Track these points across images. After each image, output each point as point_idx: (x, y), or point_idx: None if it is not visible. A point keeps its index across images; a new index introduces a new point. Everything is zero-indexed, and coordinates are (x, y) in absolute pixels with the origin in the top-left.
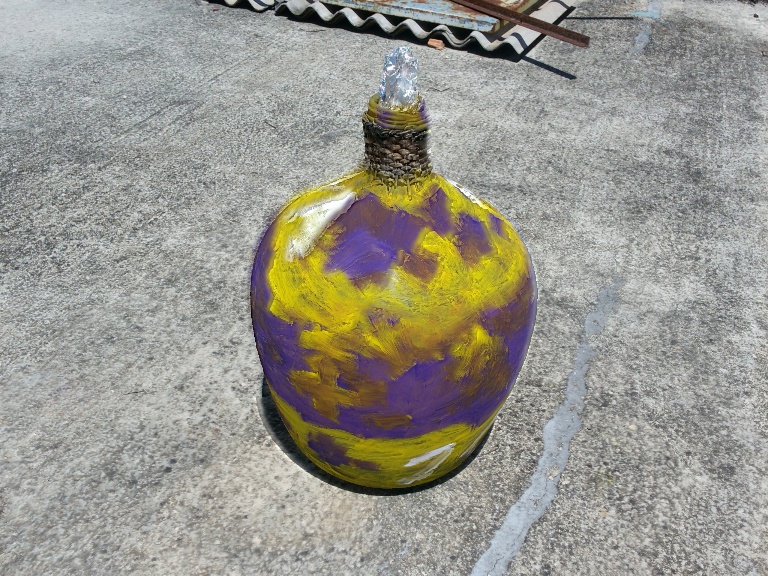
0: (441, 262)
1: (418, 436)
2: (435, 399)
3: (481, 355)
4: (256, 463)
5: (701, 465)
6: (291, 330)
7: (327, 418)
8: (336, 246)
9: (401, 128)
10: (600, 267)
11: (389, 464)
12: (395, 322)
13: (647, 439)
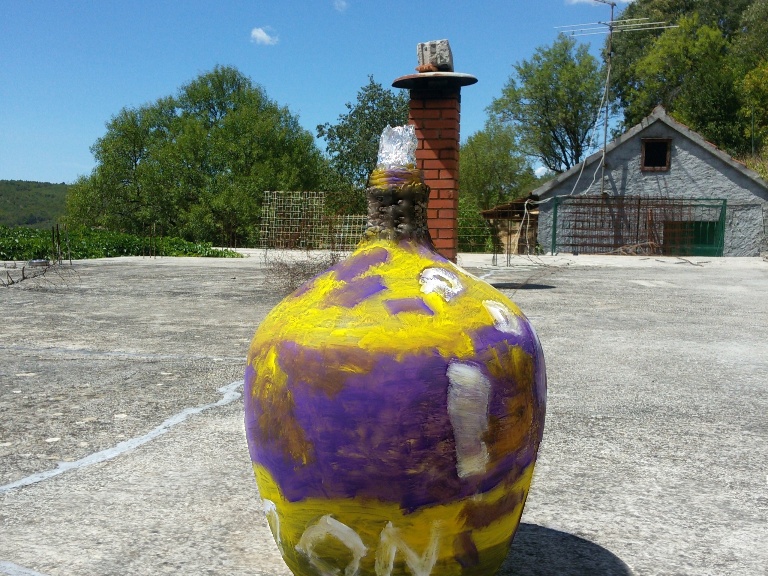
0: (307, 290)
1: None
2: None
3: None
4: None
5: None
6: None
7: None
8: None
9: None
10: None
11: None
12: None
13: None
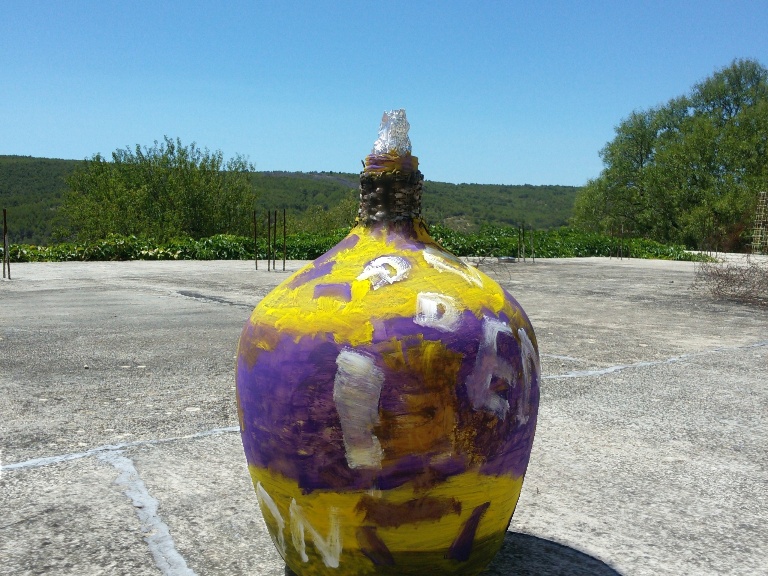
0: None
1: None
2: None
3: None
4: None
5: None
6: None
7: None
8: None
9: None
10: None
11: None
12: None
13: None
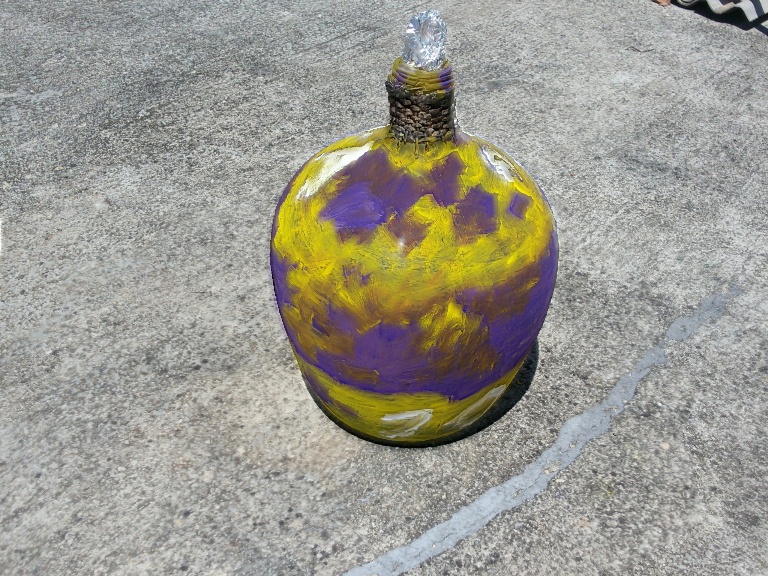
0: (428, 227)
1: (388, 393)
2: (401, 361)
3: (452, 328)
4: (274, 381)
5: (720, 504)
6: (283, 263)
7: (309, 354)
8: (335, 191)
9: (413, 84)
10: (721, 270)
11: (366, 413)
12: (365, 276)
13: (673, 461)
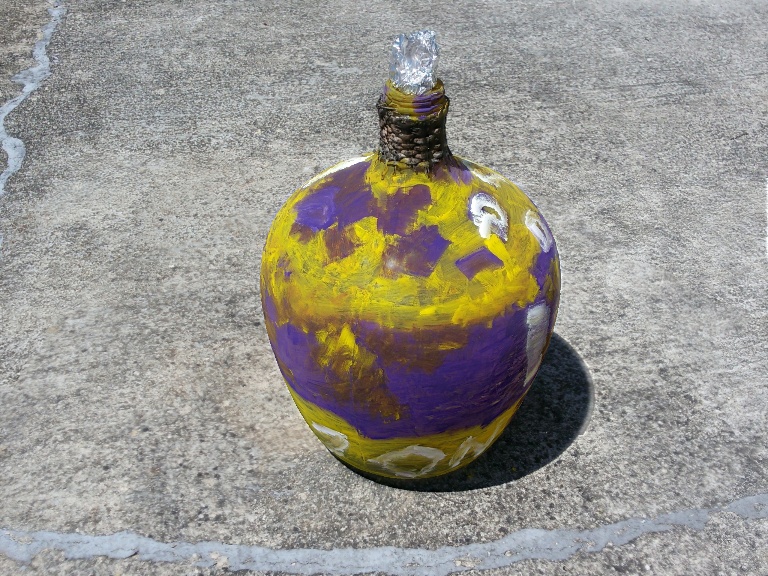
0: (355, 247)
1: (305, 399)
2: (305, 369)
3: (343, 355)
4: None
5: None
6: None
7: None
8: (314, 189)
9: (388, 103)
10: None
11: None
12: (287, 273)
13: None
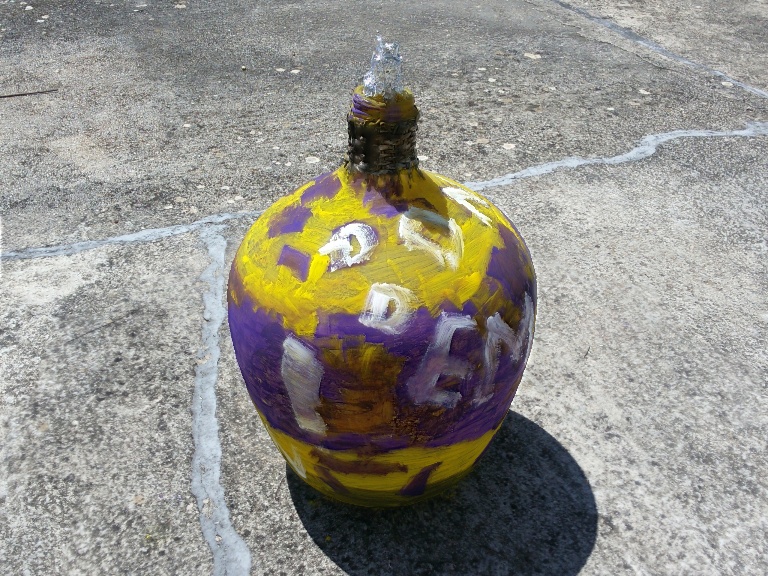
0: (292, 193)
1: None
2: None
3: None
4: None
5: None
6: None
7: None
8: None
9: None
10: None
11: None
12: None
13: None
